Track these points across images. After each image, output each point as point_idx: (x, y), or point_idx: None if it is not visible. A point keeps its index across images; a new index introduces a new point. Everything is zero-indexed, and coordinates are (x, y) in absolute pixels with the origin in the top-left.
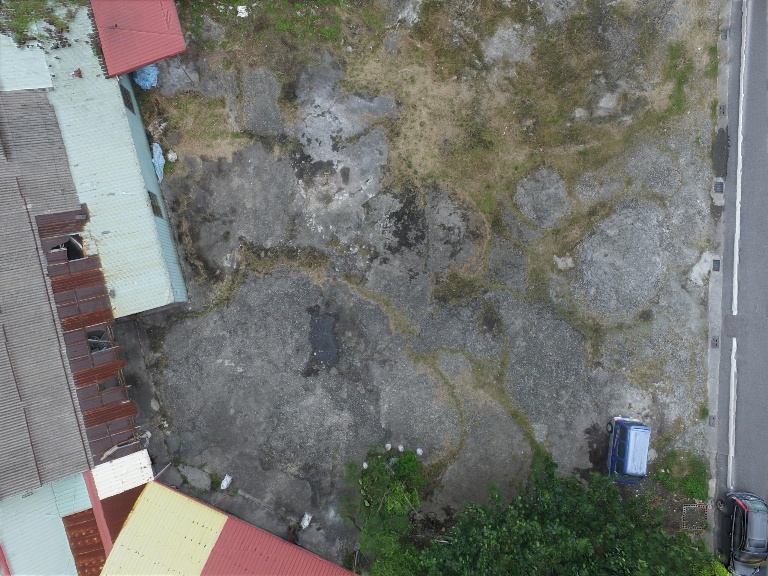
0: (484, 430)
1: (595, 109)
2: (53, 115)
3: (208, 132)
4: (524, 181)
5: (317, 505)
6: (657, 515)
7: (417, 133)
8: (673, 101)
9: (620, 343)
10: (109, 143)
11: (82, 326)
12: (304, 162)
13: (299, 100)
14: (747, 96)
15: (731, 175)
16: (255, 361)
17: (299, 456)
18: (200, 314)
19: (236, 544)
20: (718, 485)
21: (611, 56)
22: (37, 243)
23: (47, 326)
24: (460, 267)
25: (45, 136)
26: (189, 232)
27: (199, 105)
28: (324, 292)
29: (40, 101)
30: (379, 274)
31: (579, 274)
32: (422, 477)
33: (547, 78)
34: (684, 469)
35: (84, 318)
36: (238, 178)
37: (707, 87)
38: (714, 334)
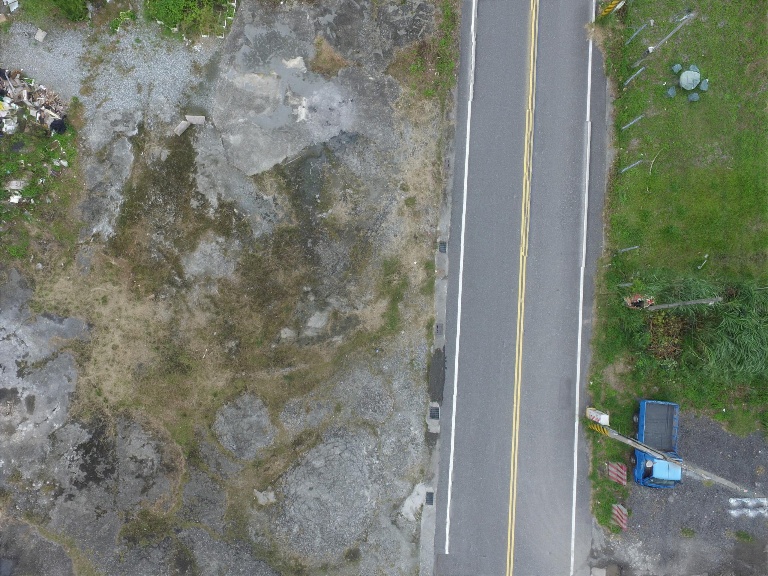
0: None
1: (302, 329)
2: None
3: None
4: (224, 408)
5: None
6: None
7: (108, 358)
8: (386, 320)
9: None
10: None
11: None
12: None
13: None
14: (465, 314)
15: (447, 399)
16: None
17: None
18: None
19: None
20: None
21: (320, 272)
22: None
23: None
24: (152, 503)
25: None
26: None
27: None
28: (3, 533)
29: None
30: (63, 513)
31: (281, 510)
32: None
33: (251, 296)
34: None
35: None
36: None
37: (423, 304)
38: (425, 575)
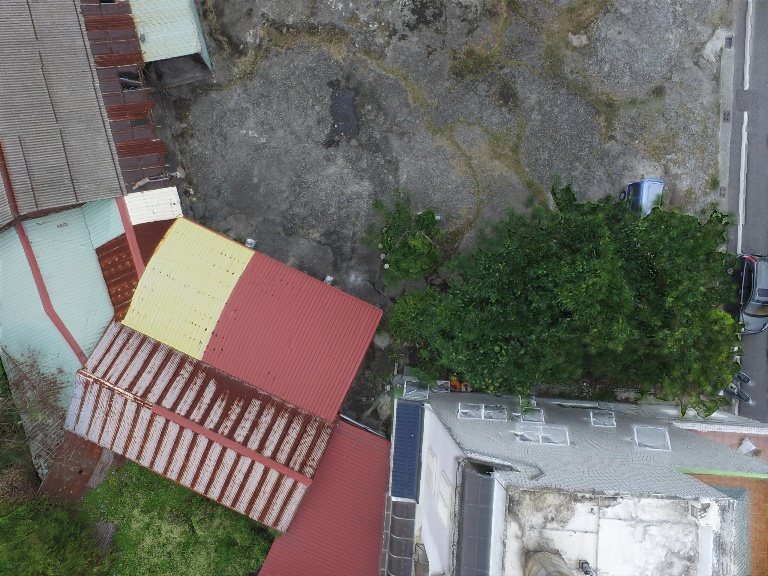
0: (500, 199)
1: None
2: None
3: None
4: None
5: (338, 269)
6: None
7: None
8: None
9: (633, 117)
10: None
11: (114, 65)
12: None
13: None
14: None
15: None
16: (278, 132)
17: (320, 223)
18: (224, 87)
19: (262, 275)
20: None
21: None
22: None
23: (81, 59)
24: (477, 44)
25: None
26: (213, 8)
27: None
28: (344, 67)
29: None
30: (398, 50)
31: (593, 51)
32: (440, 244)
33: None
34: None
35: (116, 58)
36: None
37: None
38: (725, 109)
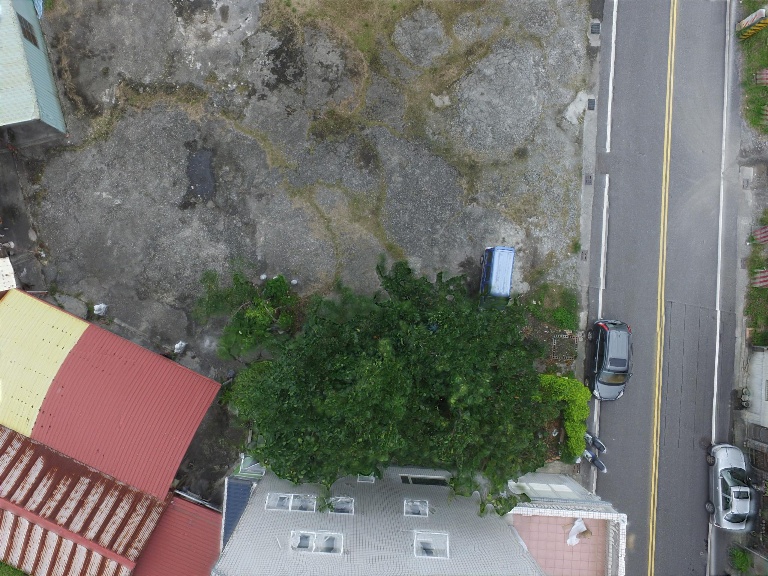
0: (359, 263)
1: None
2: None
3: None
4: (402, 20)
5: (192, 334)
6: (527, 345)
7: None
8: None
9: (495, 179)
10: None
11: None
12: None
13: None
14: None
15: (607, 16)
16: (133, 194)
17: (175, 287)
18: (78, 147)
19: (95, 348)
20: (589, 318)
21: None
22: None
23: None
24: (338, 104)
25: None
26: (68, 67)
27: None
28: (202, 127)
29: None
30: (257, 110)
31: (455, 112)
32: (297, 308)
33: None
34: (555, 301)
35: None
36: (118, 15)
37: None
38: (588, 171)
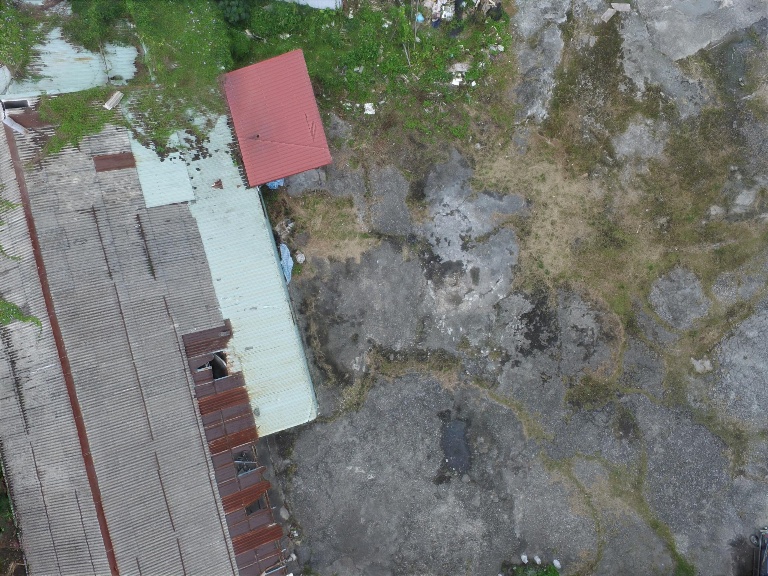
0: (622, 541)
1: (731, 206)
2: (196, 229)
3: (336, 232)
4: (659, 281)
5: None
6: None
7: (549, 232)
8: None
9: (762, 450)
10: (250, 255)
11: (229, 447)
12: (433, 262)
13: (427, 199)
14: None
15: None
16: (386, 468)
17: (432, 567)
18: (329, 419)
19: None
20: None
21: (747, 151)
22: (185, 363)
23: (196, 450)
24: (594, 370)
25: (189, 251)
26: (317, 335)
27: (326, 204)
28: (455, 396)
29: (183, 215)
30: (511, 378)
31: (718, 377)
32: None
33: (681, 174)
34: None
35: (230, 439)
36: (366, 279)
37: None
38: None
